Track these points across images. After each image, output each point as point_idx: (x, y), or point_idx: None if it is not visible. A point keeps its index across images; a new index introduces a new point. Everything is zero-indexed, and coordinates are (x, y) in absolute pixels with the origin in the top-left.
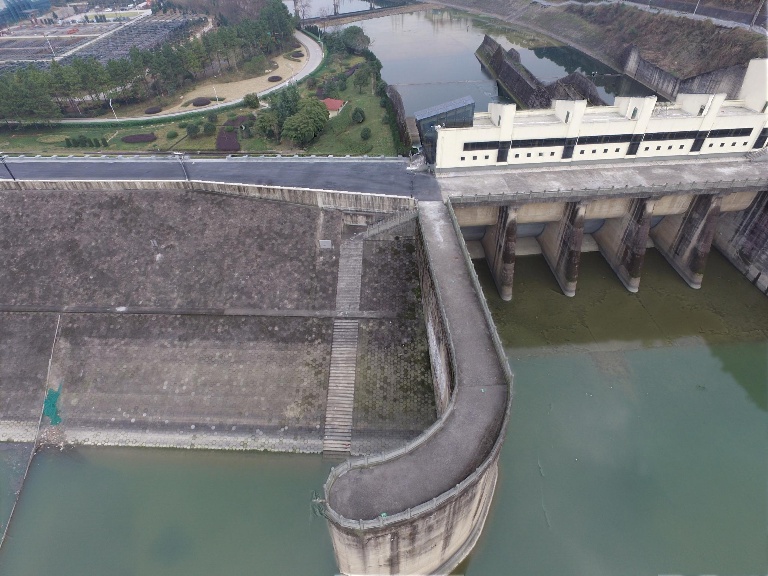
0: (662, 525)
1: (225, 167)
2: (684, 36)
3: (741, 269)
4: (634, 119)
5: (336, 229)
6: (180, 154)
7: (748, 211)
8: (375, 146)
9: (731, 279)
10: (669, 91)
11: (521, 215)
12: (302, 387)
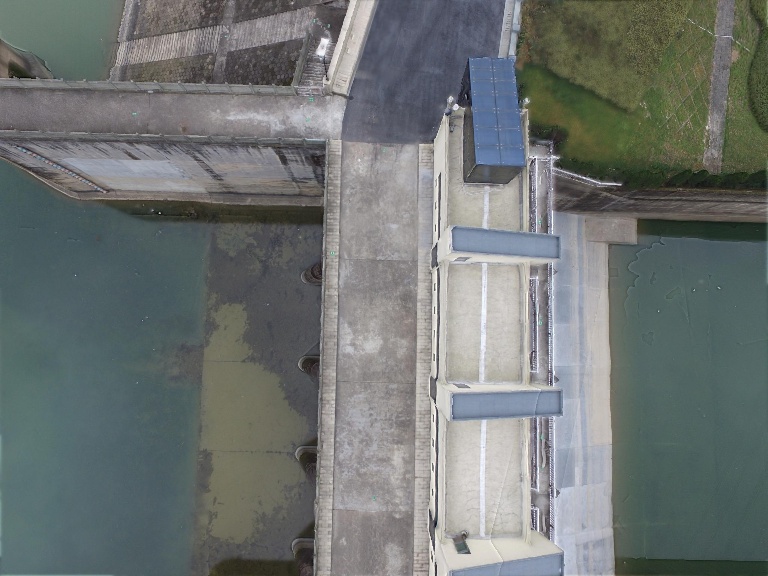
0: (13, 327)
1: None
2: None
3: None
4: None
5: None
6: None
7: None
8: None
9: None
10: None
11: None
12: (166, 8)
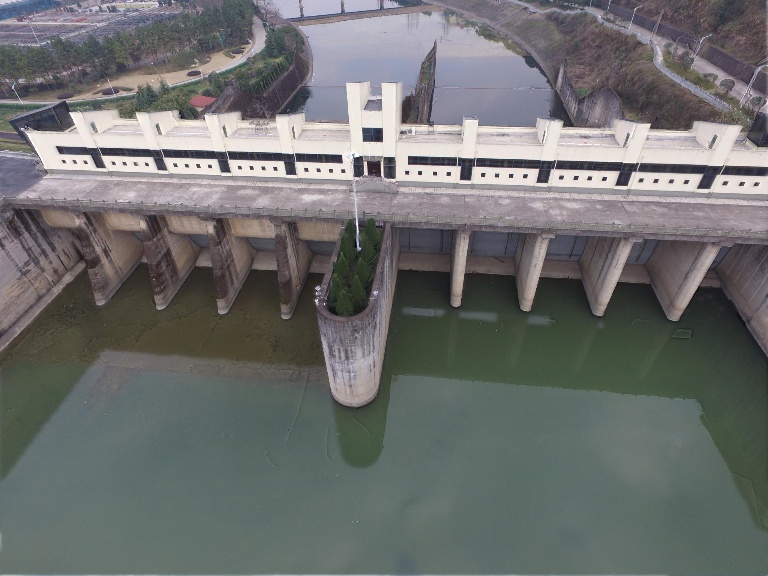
0: None
1: None
2: (612, 51)
3: None
4: None
5: None
6: None
7: None
8: None
9: None
10: (572, 111)
11: (116, 222)
12: None
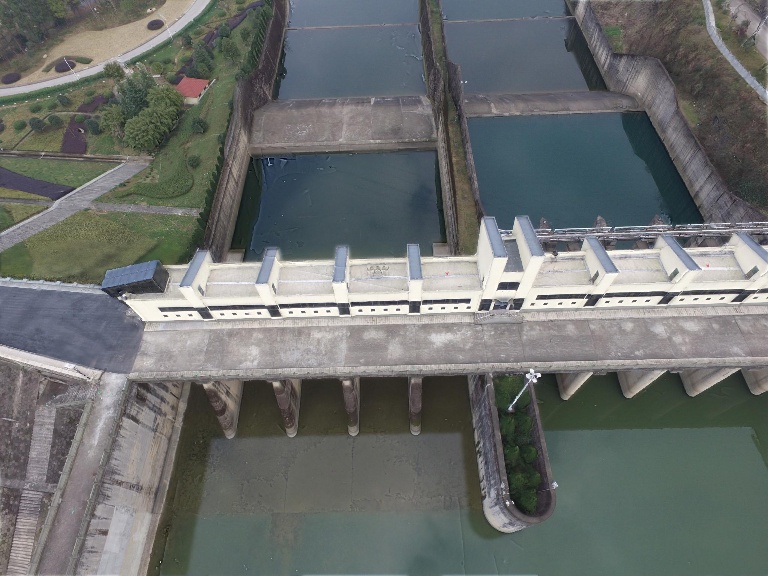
0: None
1: None
2: None
3: (471, 411)
4: None
5: (32, 393)
6: None
7: None
8: (195, 184)
9: (457, 422)
10: (602, 61)
11: None
12: None
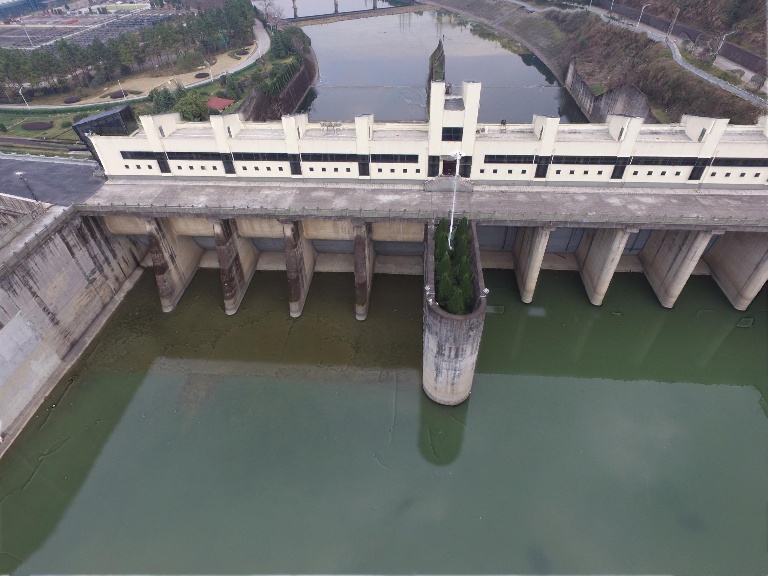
0: (83, 556)
1: None
2: (622, 49)
3: (423, 304)
4: (284, 138)
5: None
6: None
7: (426, 243)
8: None
9: (407, 314)
10: (587, 108)
11: (183, 228)
12: None
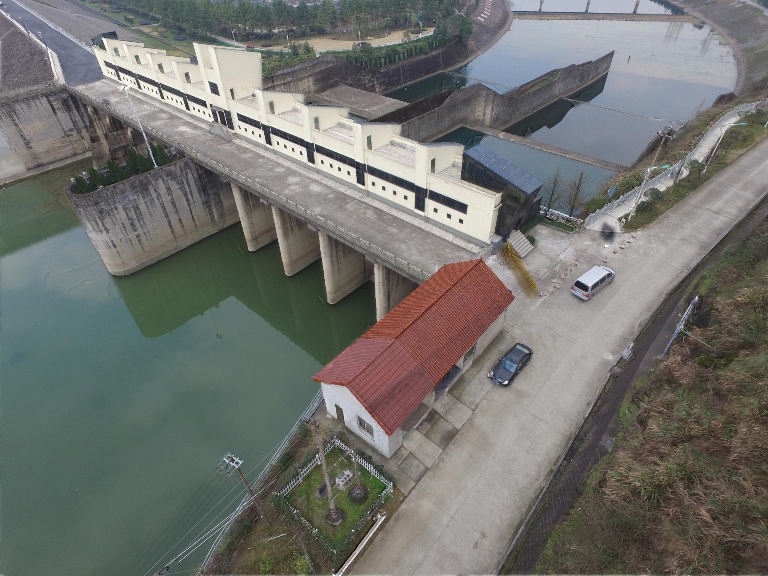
0: None
1: (81, 52)
2: None
3: None
4: None
5: None
6: (39, 33)
7: None
8: None
9: None
10: None
11: None
12: None
